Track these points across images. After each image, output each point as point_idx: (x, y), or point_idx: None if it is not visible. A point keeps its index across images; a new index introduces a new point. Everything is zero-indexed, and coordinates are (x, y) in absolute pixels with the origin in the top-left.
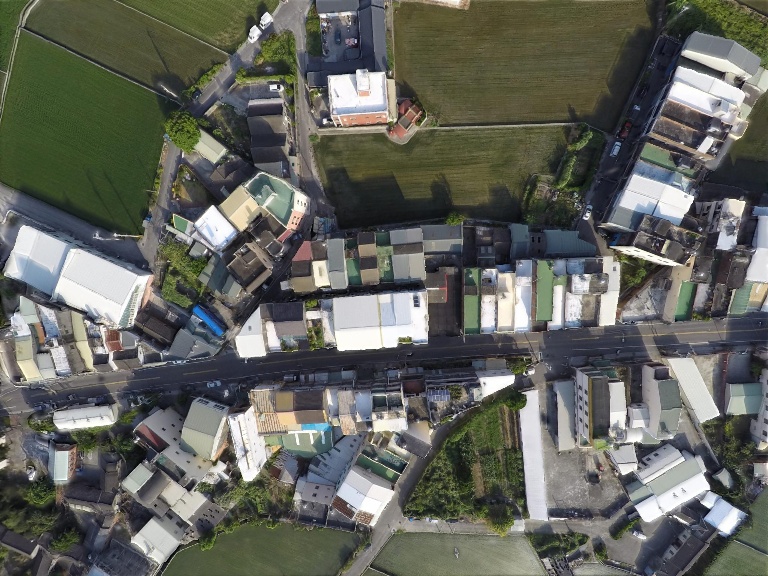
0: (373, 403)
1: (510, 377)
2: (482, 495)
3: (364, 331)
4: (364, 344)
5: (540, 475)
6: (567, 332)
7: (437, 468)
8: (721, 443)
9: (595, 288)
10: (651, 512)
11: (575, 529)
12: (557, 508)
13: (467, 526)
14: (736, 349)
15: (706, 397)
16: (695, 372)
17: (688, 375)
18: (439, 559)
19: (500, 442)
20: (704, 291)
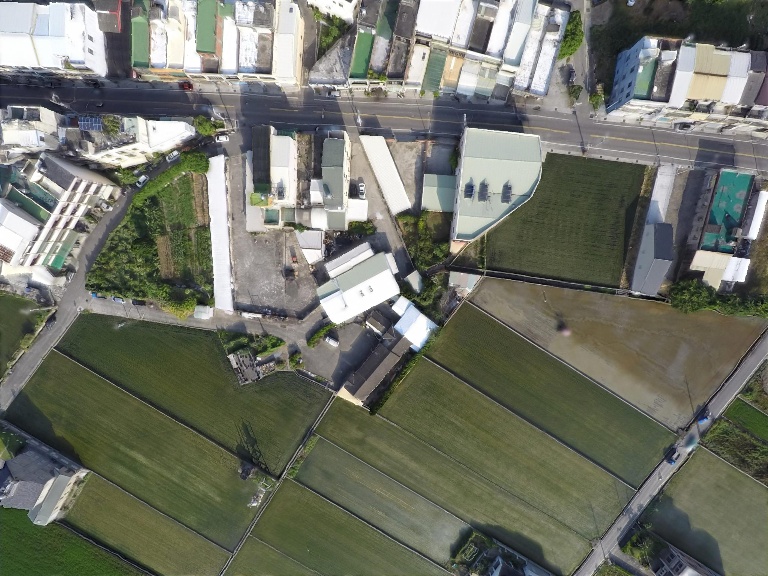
0: (12, 116)
1: (180, 123)
2: (168, 275)
3: (14, 39)
4: (18, 58)
5: (226, 256)
6: (265, 100)
7: (124, 239)
8: (416, 243)
9: (259, 20)
10: (336, 309)
11: (270, 331)
12: (252, 304)
13: (157, 313)
14: (438, 140)
15: (397, 184)
16: (386, 153)
17: (379, 156)
18: (127, 349)
19: (192, 218)
20: (384, 48)
